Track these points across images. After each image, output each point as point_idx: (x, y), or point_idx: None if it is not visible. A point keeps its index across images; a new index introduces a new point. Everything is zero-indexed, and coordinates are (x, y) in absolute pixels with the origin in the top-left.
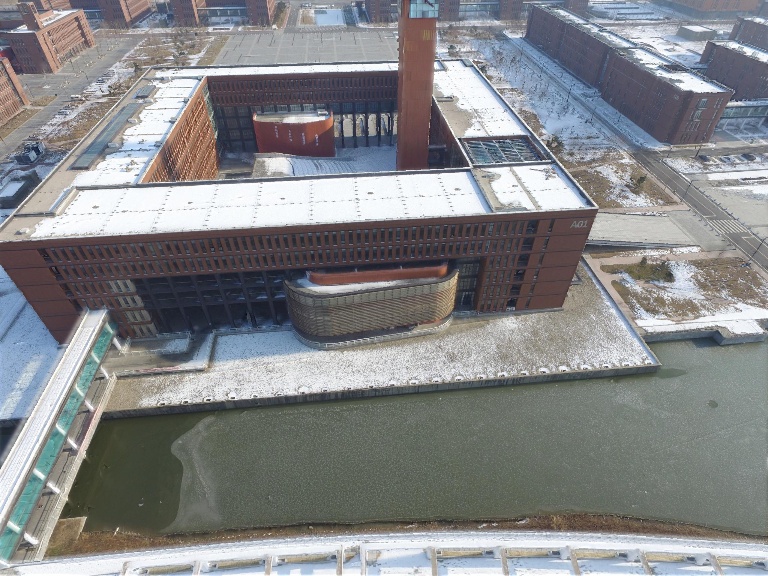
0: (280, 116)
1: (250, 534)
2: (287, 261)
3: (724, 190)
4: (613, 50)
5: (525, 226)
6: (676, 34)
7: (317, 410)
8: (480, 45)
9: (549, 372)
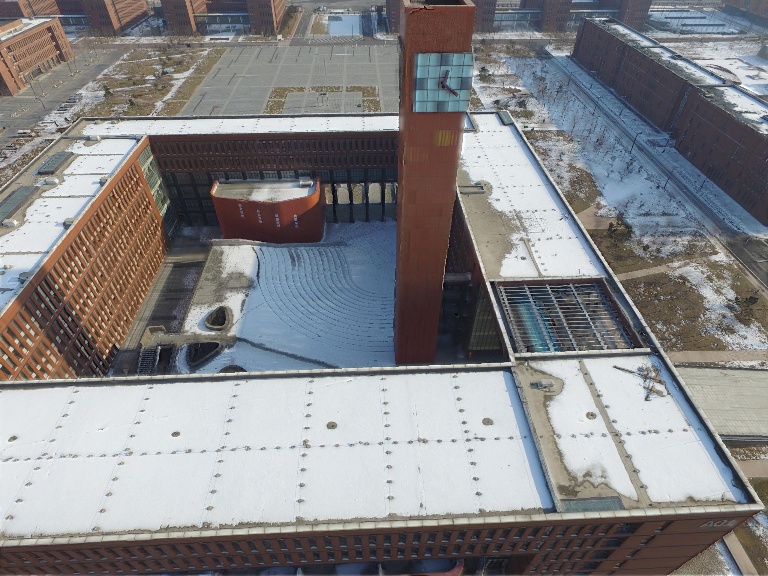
0: (249, 186)
1: None
2: (170, 564)
3: None
4: (695, 89)
5: (614, 527)
6: (757, 54)
7: None
8: (518, 67)
9: None
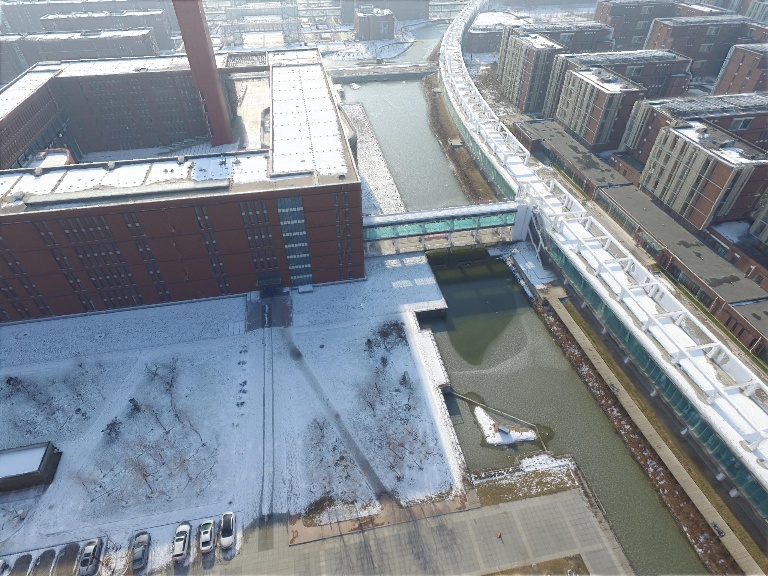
0: None
1: (464, 187)
2: None
3: None
4: (21, 41)
5: None
6: None
7: (396, 179)
8: None
9: (367, 123)
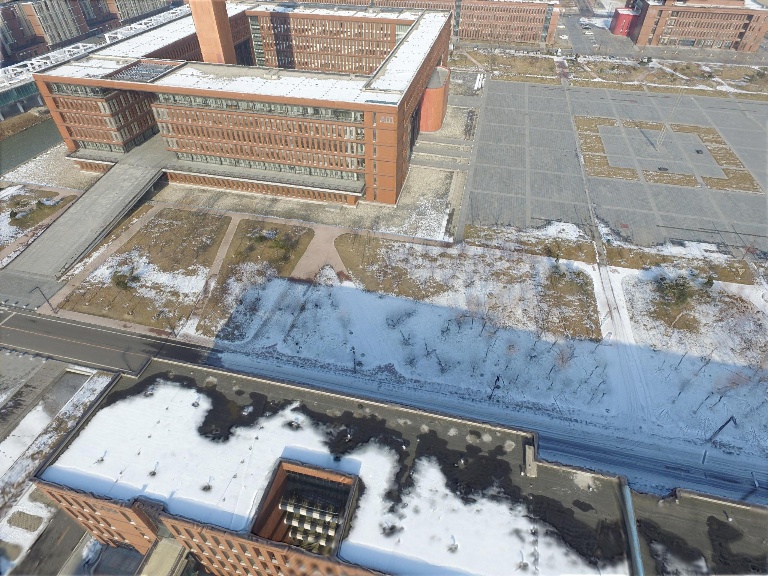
0: None
1: None
2: None
3: (4, 390)
4: None
5: None
6: None
7: None
8: None
9: None
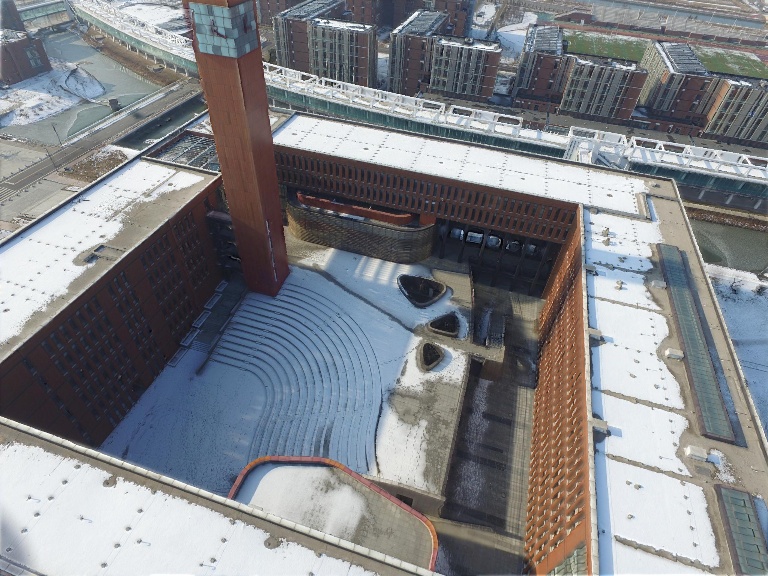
0: None
1: None
2: None
3: None
4: None
5: None
6: None
7: None
8: None
9: None
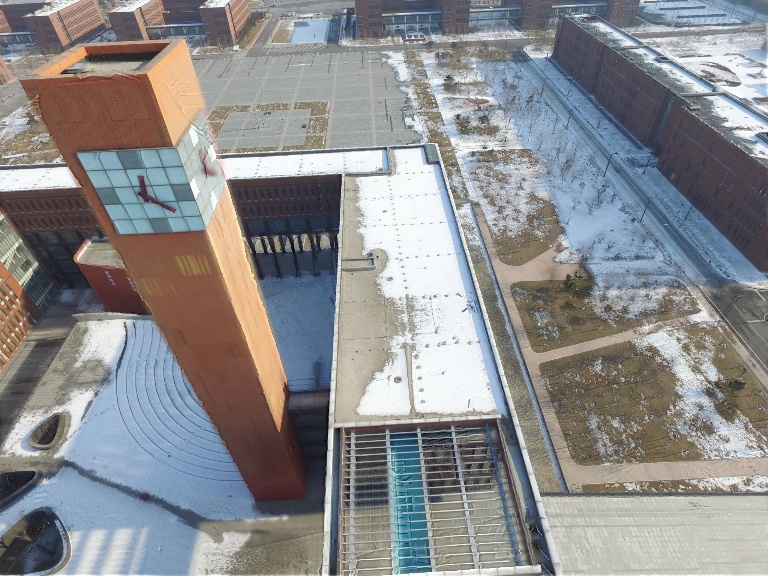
0: None
1: None
2: None
3: None
4: (678, 99)
5: None
6: (761, 48)
7: None
8: (487, 74)
9: None
